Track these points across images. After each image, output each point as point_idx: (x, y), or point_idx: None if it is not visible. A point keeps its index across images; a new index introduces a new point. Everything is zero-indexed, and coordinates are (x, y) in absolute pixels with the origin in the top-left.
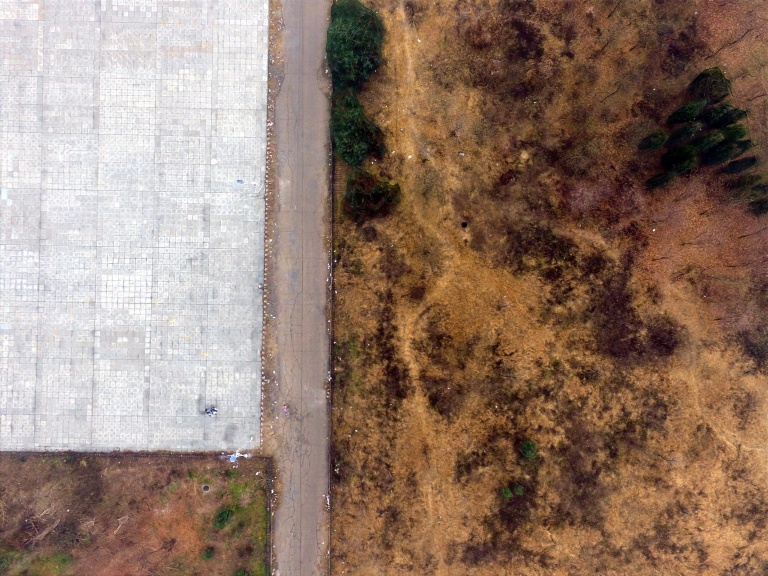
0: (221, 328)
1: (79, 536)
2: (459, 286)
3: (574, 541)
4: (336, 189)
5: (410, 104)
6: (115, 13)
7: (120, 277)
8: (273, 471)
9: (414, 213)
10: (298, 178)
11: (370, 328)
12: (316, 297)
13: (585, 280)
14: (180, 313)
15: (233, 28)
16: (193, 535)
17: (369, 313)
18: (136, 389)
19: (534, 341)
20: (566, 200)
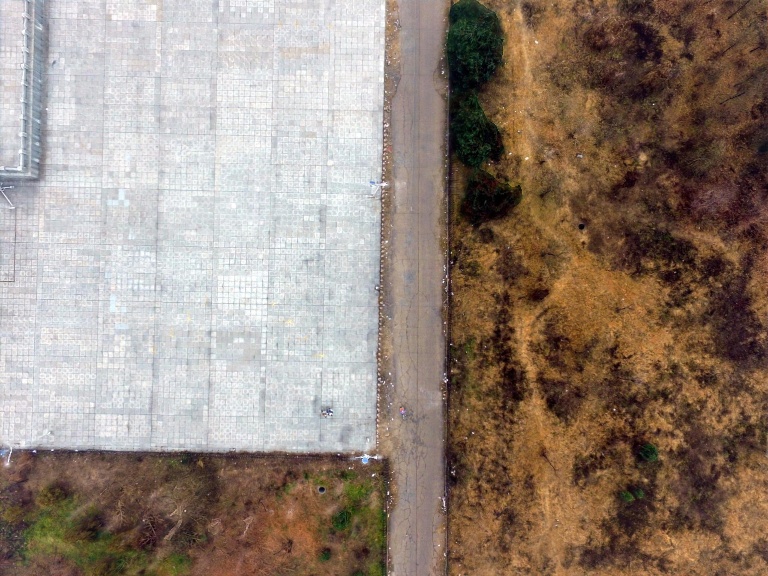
0: (337, 329)
1: (196, 536)
2: (577, 288)
3: (693, 545)
4: (453, 191)
5: (527, 106)
6: (232, 14)
7: (236, 278)
8: (389, 473)
9: (531, 215)
10: (414, 179)
11: (487, 330)
12: (432, 299)
13: (704, 283)
14: (296, 314)
15: (350, 29)
16: (309, 536)
17: (486, 315)
18: (252, 390)
19: (653, 344)
20: (685, 202)
